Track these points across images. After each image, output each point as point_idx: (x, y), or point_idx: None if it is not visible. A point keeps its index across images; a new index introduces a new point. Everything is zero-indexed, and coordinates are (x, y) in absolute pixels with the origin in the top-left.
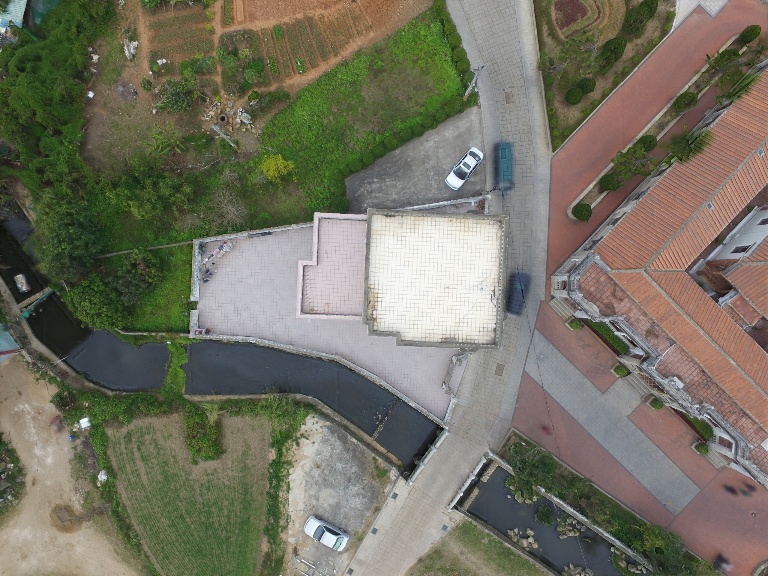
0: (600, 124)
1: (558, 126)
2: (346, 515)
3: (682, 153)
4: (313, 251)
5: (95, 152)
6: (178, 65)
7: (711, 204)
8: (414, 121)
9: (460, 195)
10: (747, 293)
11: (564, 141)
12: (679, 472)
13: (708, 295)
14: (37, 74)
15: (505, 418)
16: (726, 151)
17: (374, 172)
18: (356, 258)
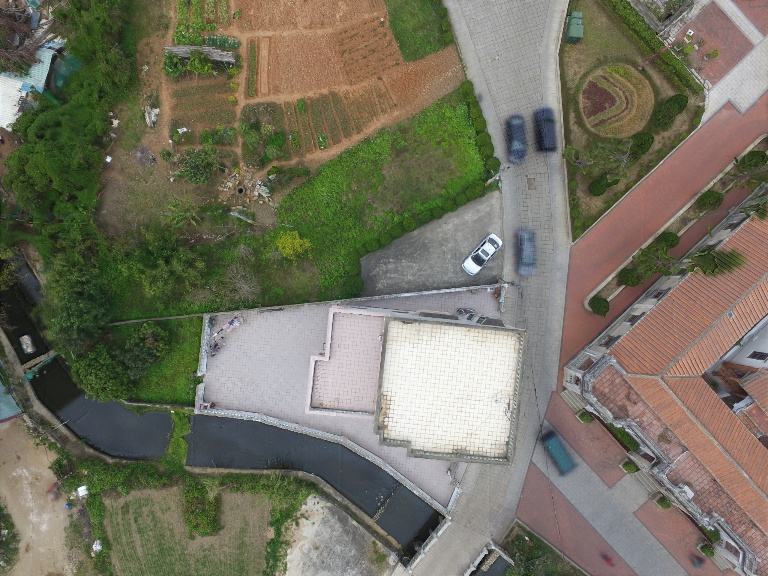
0: (622, 216)
1: (579, 215)
2: None
3: (707, 268)
4: (326, 347)
5: (109, 217)
6: (198, 134)
7: (732, 313)
8: (434, 203)
9: (476, 280)
10: (764, 404)
11: (585, 231)
12: (683, 572)
13: (723, 402)
14: (56, 141)
15: (509, 508)
16: (750, 259)
17: (390, 252)
18: (369, 354)
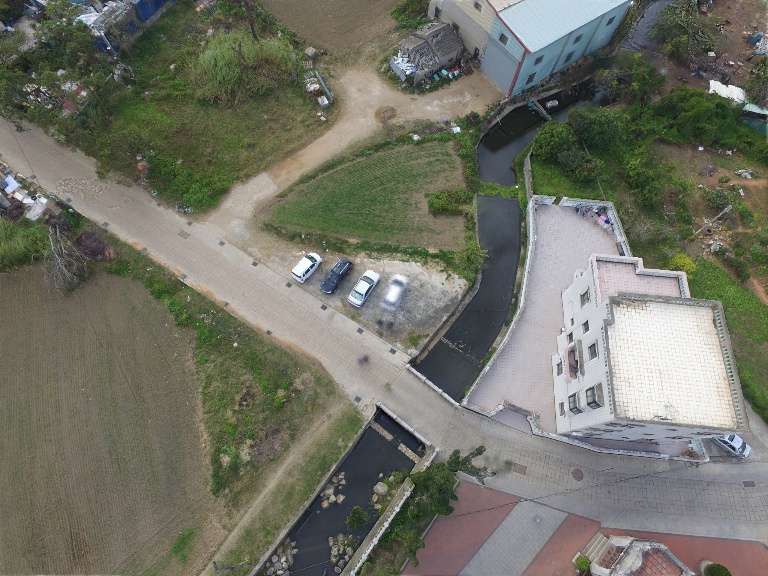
0: None
1: None
2: (377, 307)
3: None
4: None
5: None
6: None
7: None
8: (756, 389)
9: None
10: None
11: None
12: None
13: None
14: None
15: None
16: None
17: None
18: None
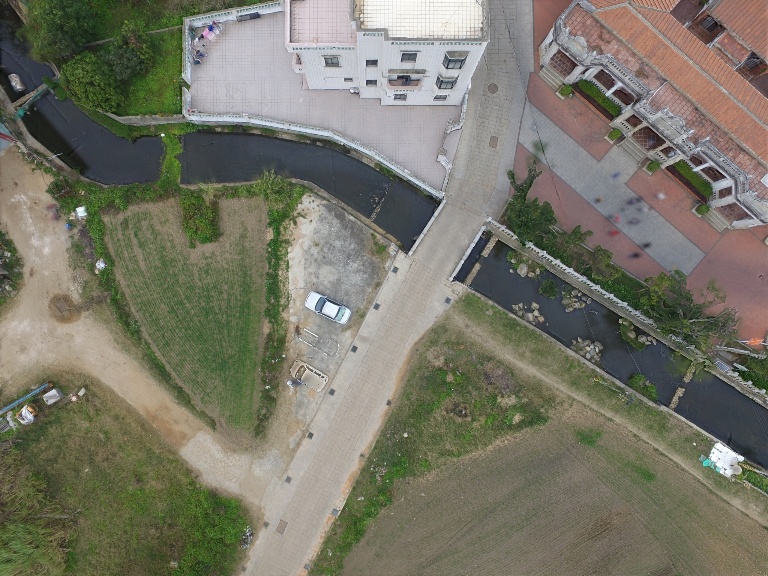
0: None
1: None
2: (347, 292)
3: None
4: None
5: None
6: None
7: None
8: None
9: None
10: (733, 27)
11: None
12: (682, 237)
13: (695, 36)
14: None
15: (502, 190)
16: None
17: None
18: None
